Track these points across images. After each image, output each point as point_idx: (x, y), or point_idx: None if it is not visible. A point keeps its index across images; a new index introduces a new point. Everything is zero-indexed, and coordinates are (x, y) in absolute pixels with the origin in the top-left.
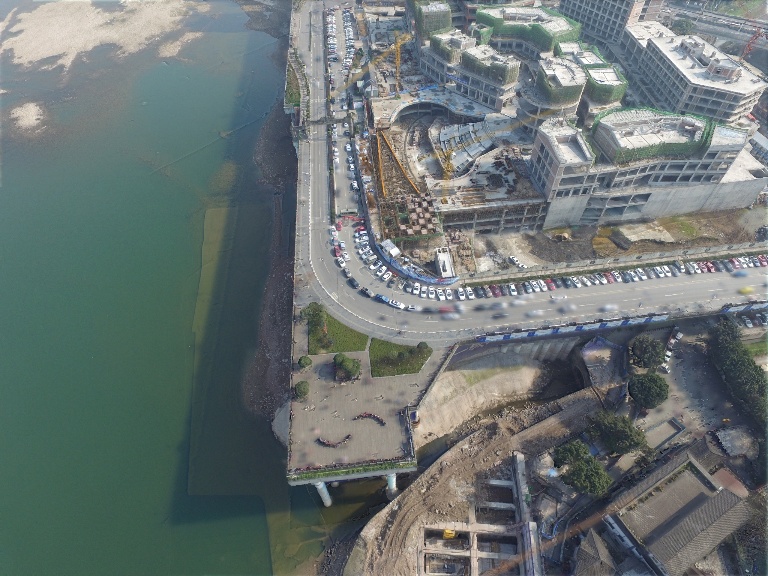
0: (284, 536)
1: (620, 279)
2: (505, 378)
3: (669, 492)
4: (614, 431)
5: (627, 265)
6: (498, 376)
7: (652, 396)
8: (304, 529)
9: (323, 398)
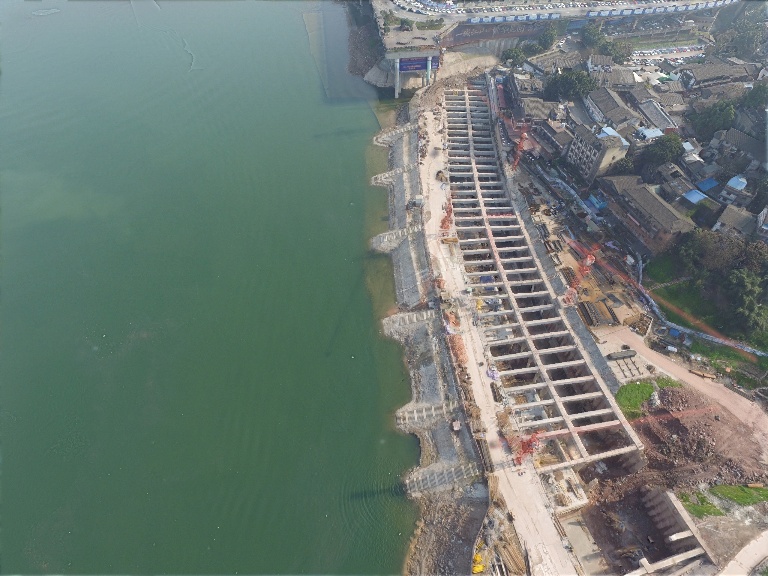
0: (378, 106)
1: (539, 8)
2: (481, 60)
3: (550, 56)
4: (529, 47)
5: (543, 4)
6: (478, 58)
7: (548, 38)
8: (387, 104)
9: (397, 35)
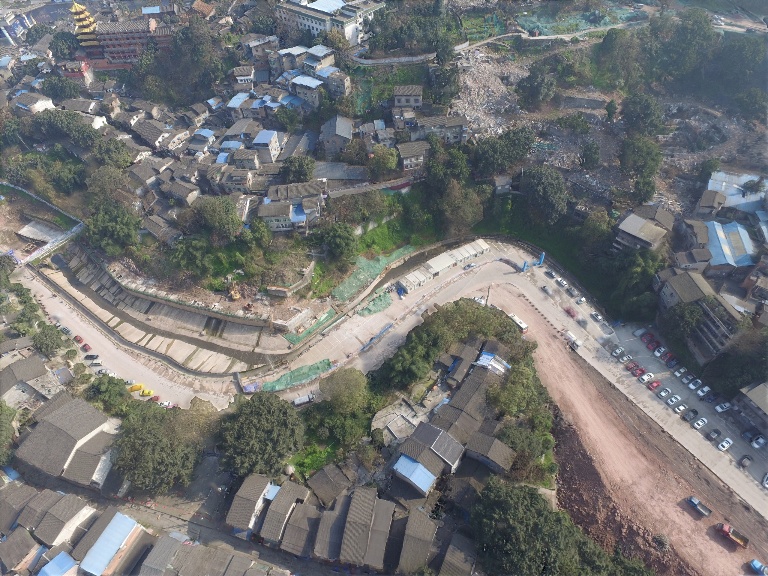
0: None
1: None
2: None
3: None
4: None
5: None
6: None
7: None
8: None
9: None
